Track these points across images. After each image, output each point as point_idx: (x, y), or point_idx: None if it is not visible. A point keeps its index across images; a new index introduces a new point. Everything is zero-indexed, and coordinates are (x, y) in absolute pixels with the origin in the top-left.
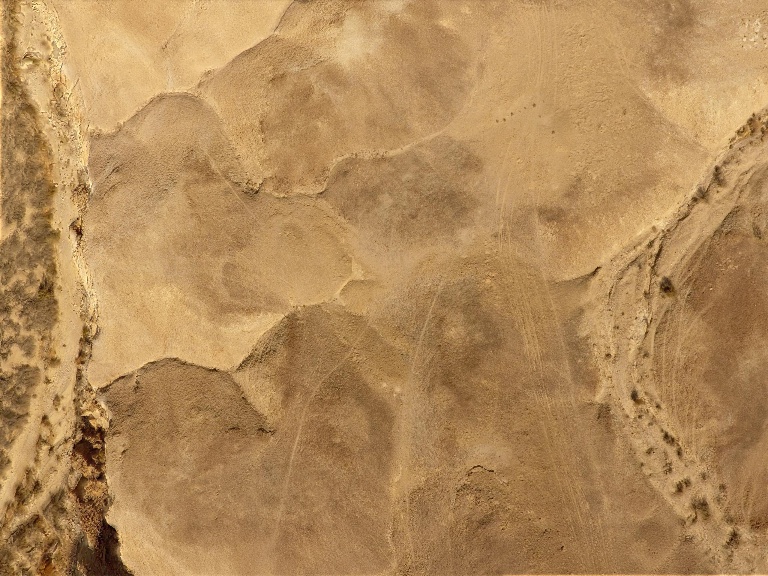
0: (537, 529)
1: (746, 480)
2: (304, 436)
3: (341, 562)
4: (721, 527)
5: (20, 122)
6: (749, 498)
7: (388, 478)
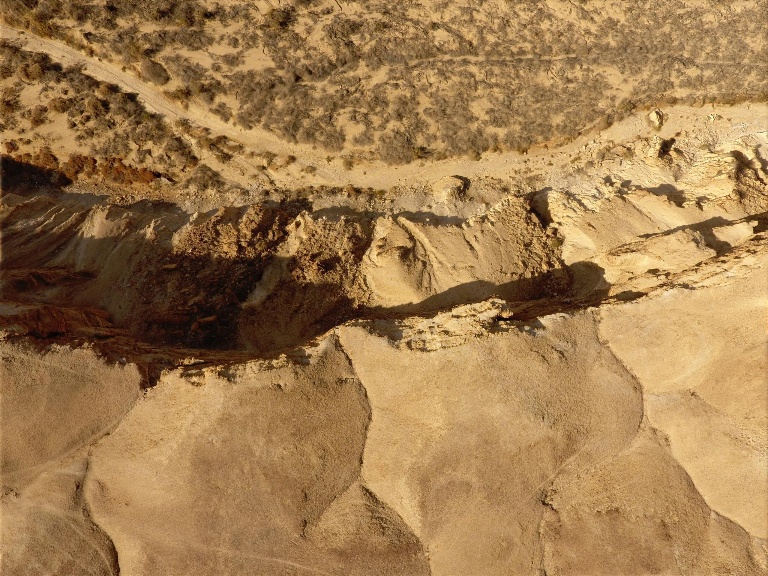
0: None
1: None
2: (301, 573)
3: None
4: None
5: (590, 115)
6: None
7: None
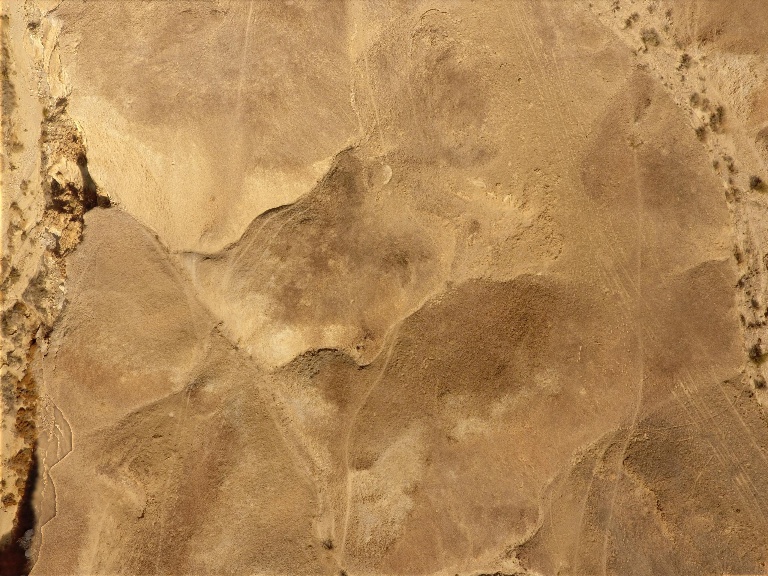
0: (493, 62)
1: (690, 1)
2: (257, 6)
3: (306, 126)
4: (671, 55)
5: None
6: (694, 18)
7: (344, 37)
